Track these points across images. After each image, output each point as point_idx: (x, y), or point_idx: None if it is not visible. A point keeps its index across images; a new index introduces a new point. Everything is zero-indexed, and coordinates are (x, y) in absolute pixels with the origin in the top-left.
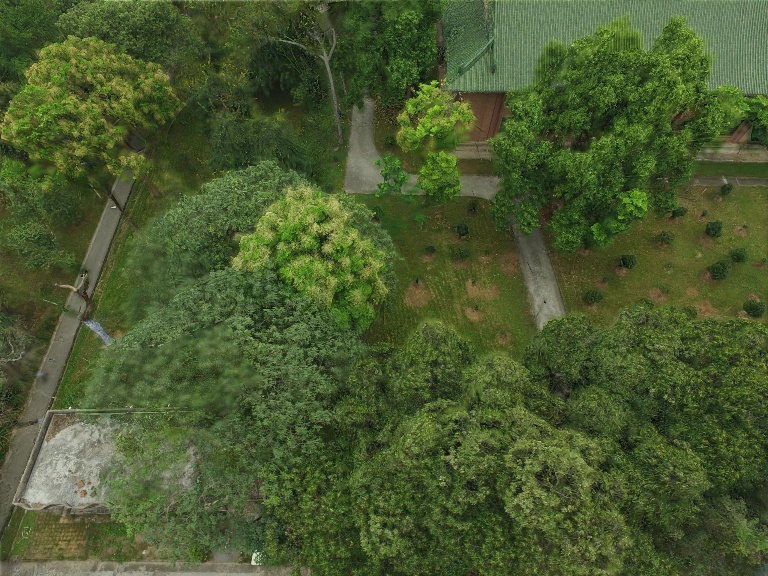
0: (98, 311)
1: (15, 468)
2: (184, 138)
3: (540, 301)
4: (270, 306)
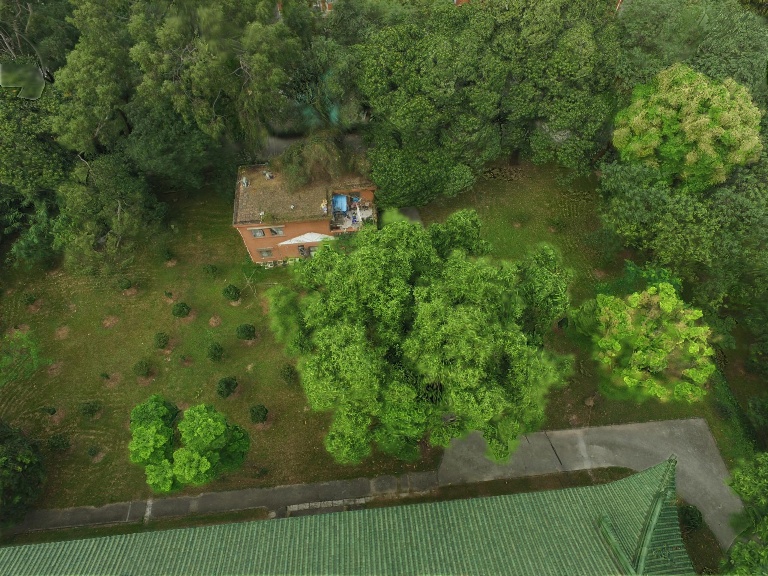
0: None
1: None
2: None
3: None
4: None
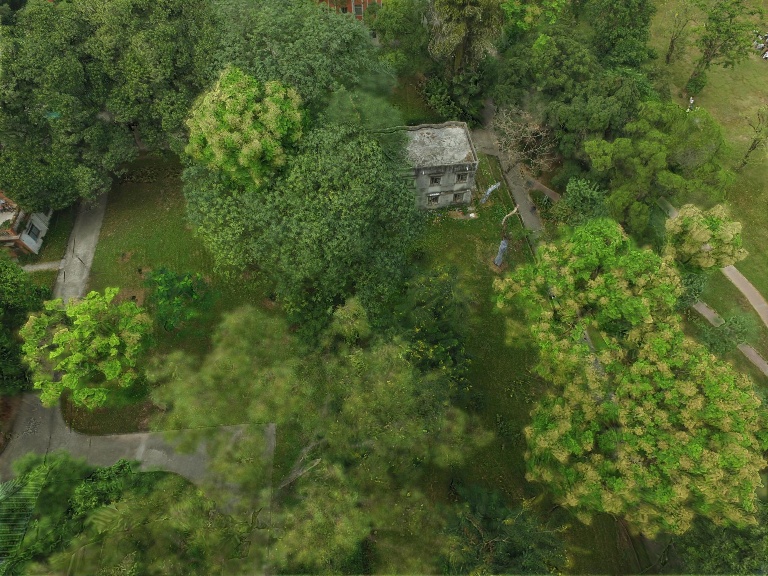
0: None
1: (519, 193)
2: None
3: None
4: (259, 59)
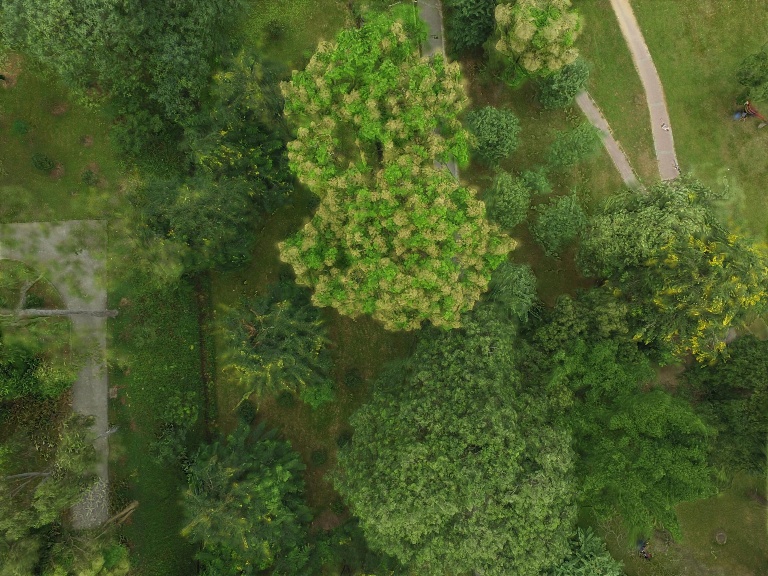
0: None
1: None
2: (390, 364)
3: None
4: None
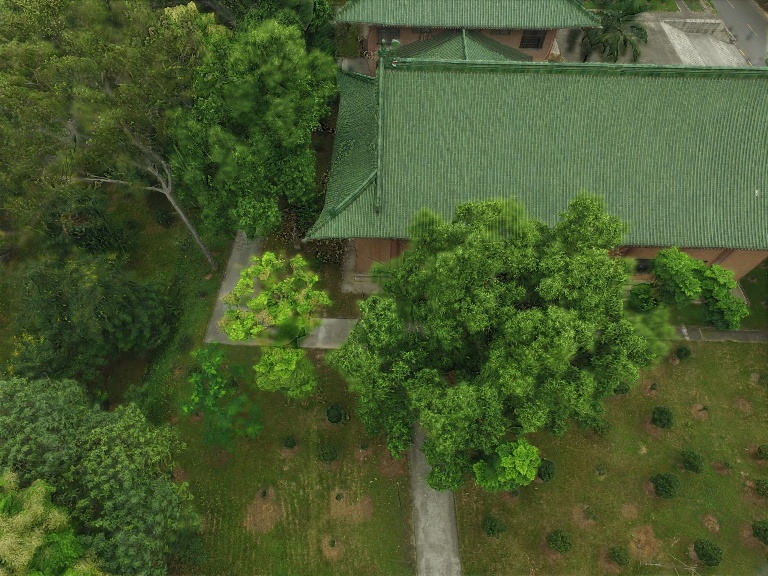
0: None
1: None
2: None
3: (427, 522)
4: None
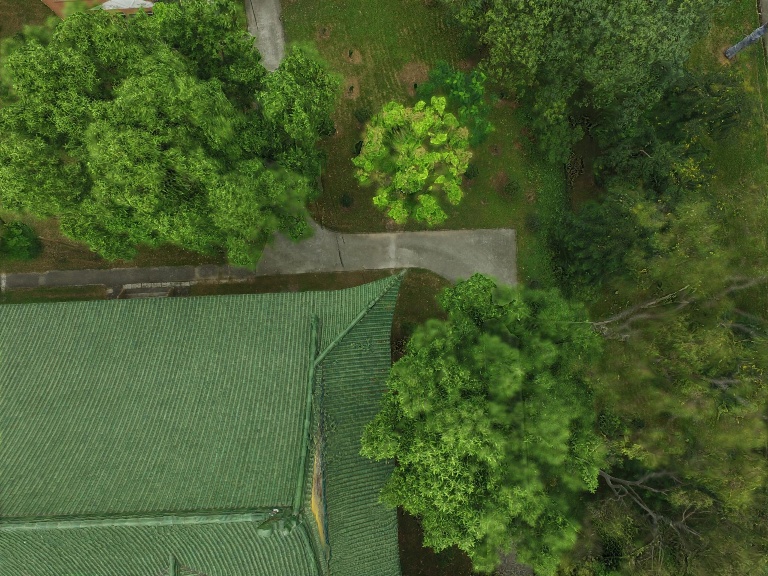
0: (759, 99)
1: None
2: None
3: None
4: None
